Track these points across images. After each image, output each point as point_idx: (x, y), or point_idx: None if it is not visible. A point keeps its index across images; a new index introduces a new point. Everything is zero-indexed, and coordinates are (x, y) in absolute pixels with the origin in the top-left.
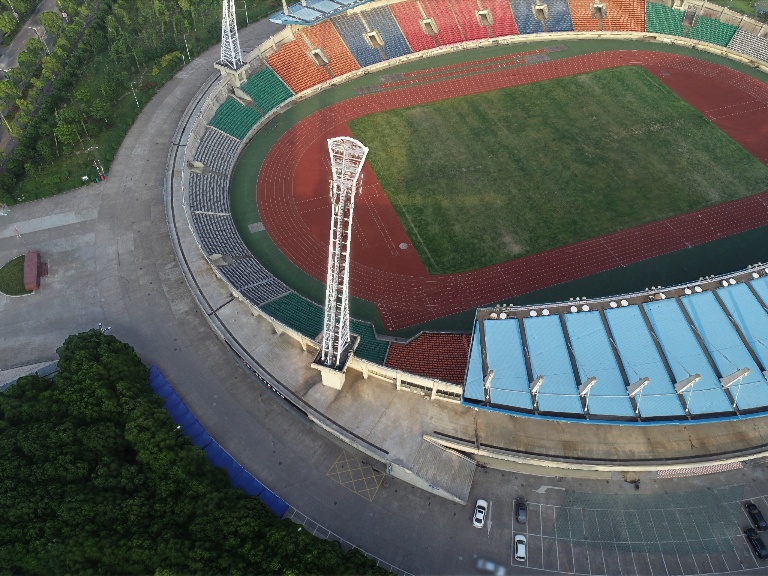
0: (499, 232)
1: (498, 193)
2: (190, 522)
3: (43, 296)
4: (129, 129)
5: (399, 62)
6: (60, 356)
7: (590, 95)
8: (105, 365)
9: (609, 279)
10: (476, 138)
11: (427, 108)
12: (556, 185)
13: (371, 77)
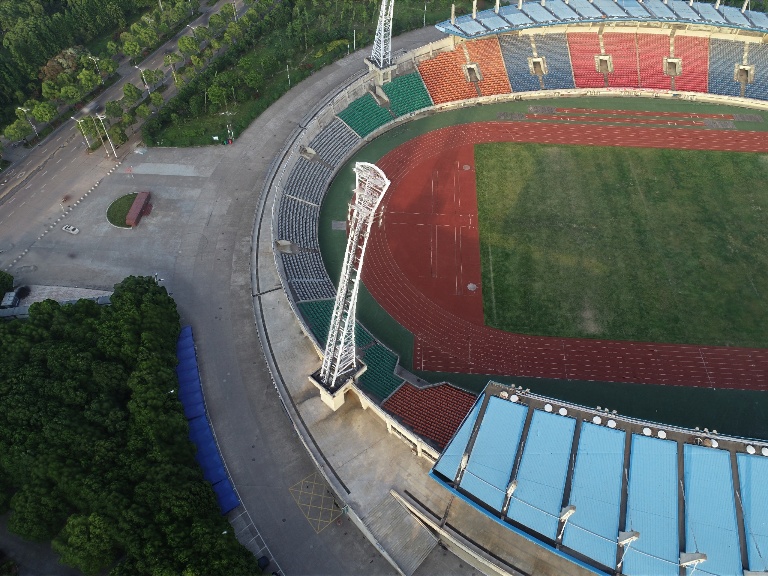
0: (582, 304)
1: (601, 261)
2: (140, 482)
3: (137, 233)
4: (273, 103)
5: (558, 95)
6: (115, 291)
7: (766, 180)
8: (142, 312)
9: (688, 397)
10: (604, 195)
11: (565, 150)
12: (674, 272)
13: (521, 104)
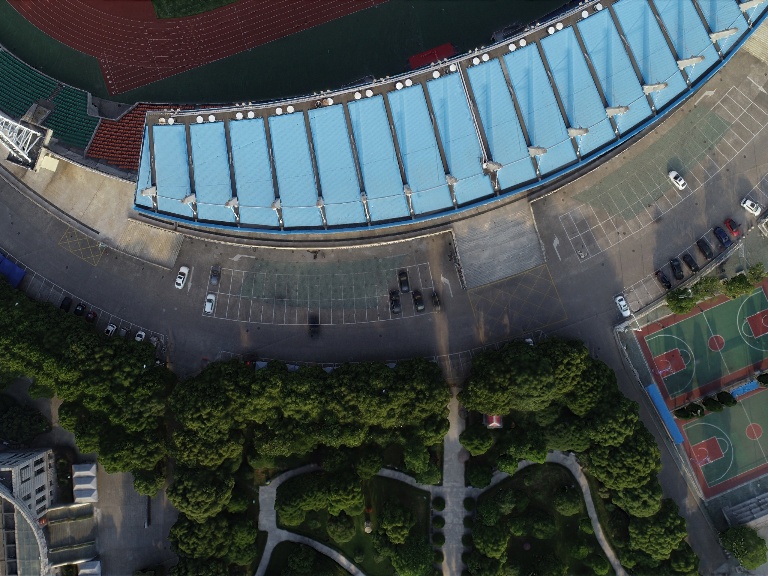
0: None
1: None
2: None
3: None
4: None
5: None
6: None
7: None
8: None
9: (354, 26)
10: None
11: None
12: None
13: None
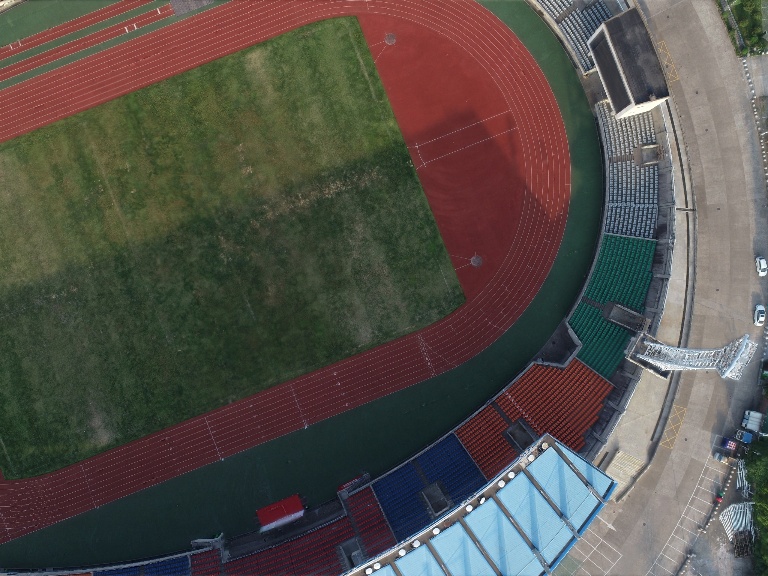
0: (88, 411)
1: (93, 342)
2: None
3: None
4: None
5: None
6: None
7: (255, 109)
8: None
9: (201, 480)
10: (74, 226)
11: (8, 155)
12: (169, 323)
13: None
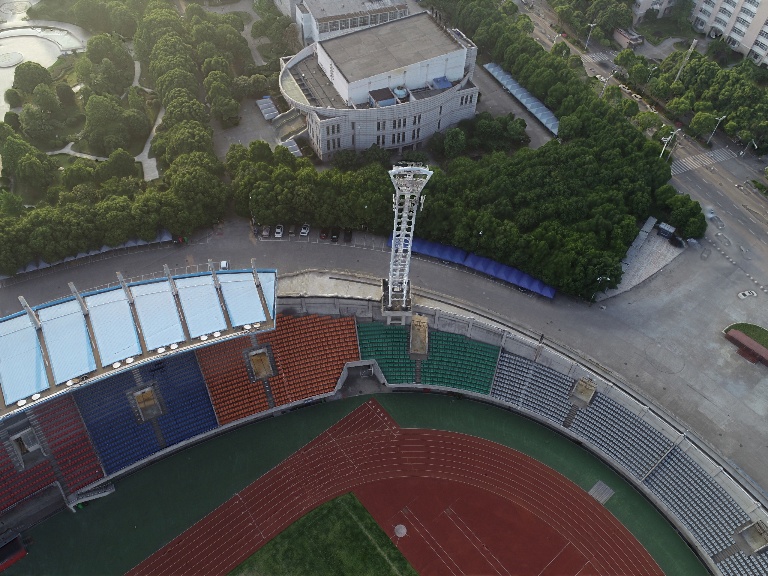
0: None
1: None
2: None
3: (712, 332)
4: None
5: None
6: None
7: None
8: None
9: (104, 570)
10: None
11: None
12: None
13: None
